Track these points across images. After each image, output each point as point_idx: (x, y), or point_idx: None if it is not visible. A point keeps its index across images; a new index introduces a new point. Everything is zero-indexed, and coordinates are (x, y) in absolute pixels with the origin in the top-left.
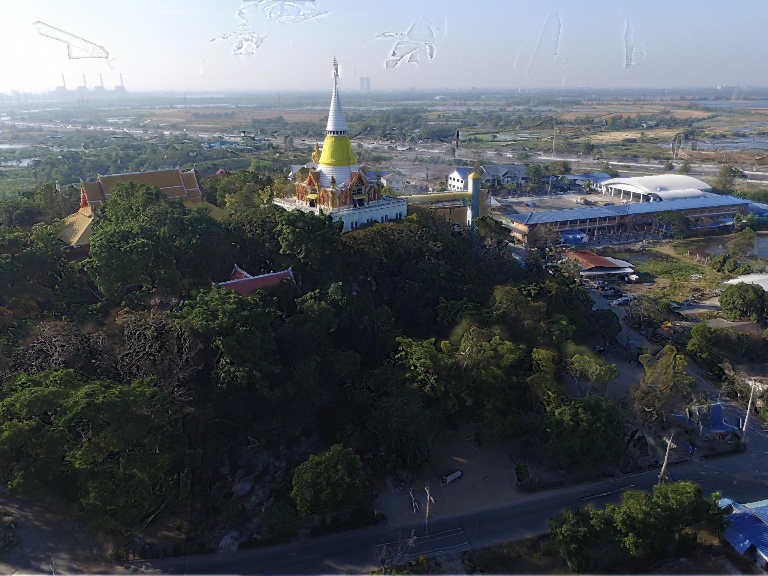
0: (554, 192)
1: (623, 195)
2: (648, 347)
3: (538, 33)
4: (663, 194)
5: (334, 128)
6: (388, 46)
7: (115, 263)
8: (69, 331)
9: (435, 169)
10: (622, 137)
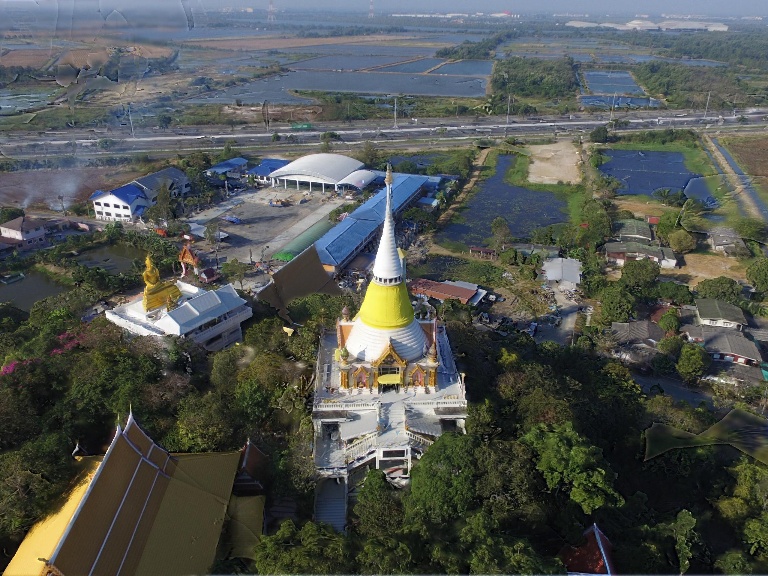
0: (228, 195)
1: (299, 186)
2: None
3: None
4: (356, 183)
5: (397, 274)
6: None
7: None
8: None
9: (4, 182)
10: (142, 92)
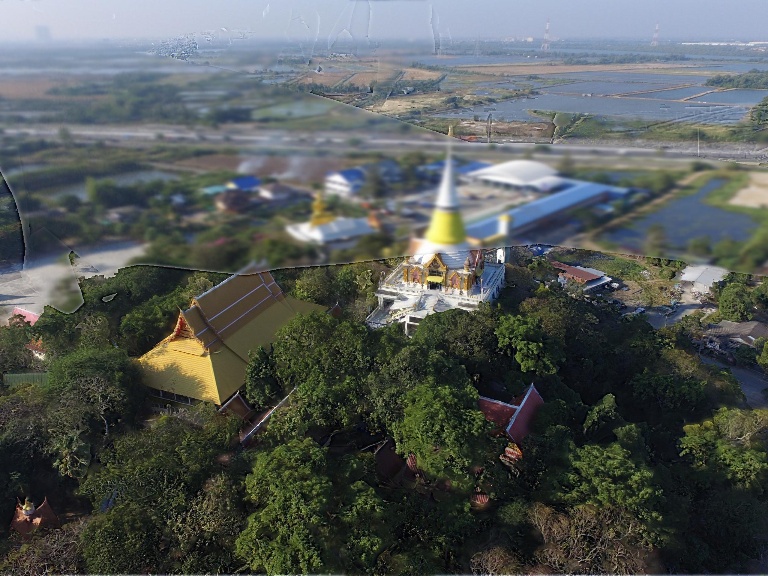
0: None
1: None
2: (707, 361)
3: (349, 15)
4: None
5: None
6: (257, 45)
7: (482, 453)
8: (510, 560)
9: None
10: (400, 107)
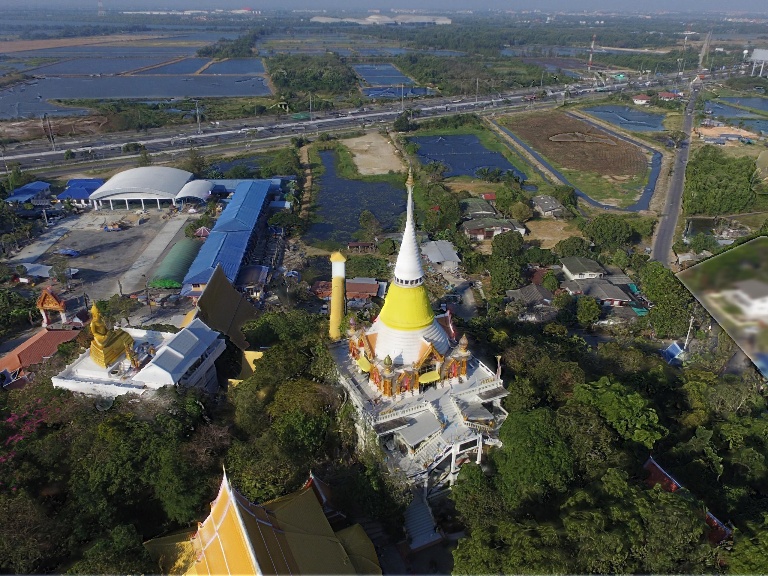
0: (46, 226)
1: (129, 205)
2: None
3: None
4: (198, 195)
5: None
6: None
7: None
8: None
9: None
10: None
